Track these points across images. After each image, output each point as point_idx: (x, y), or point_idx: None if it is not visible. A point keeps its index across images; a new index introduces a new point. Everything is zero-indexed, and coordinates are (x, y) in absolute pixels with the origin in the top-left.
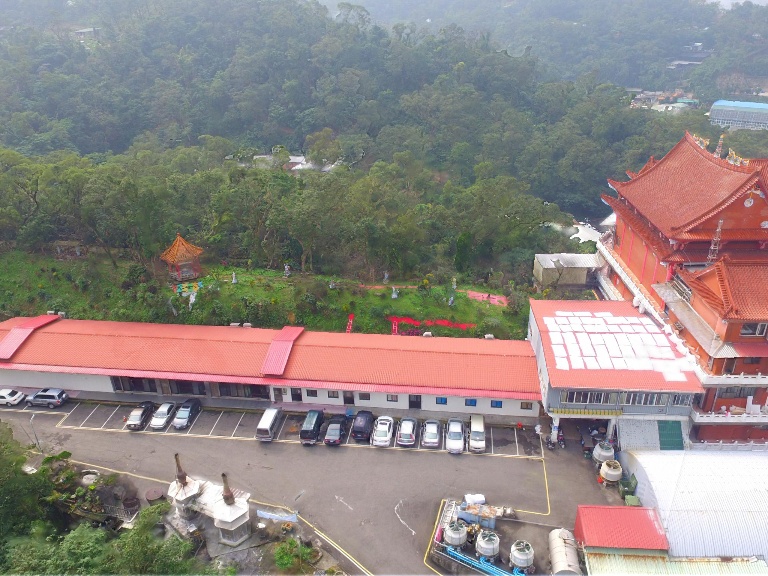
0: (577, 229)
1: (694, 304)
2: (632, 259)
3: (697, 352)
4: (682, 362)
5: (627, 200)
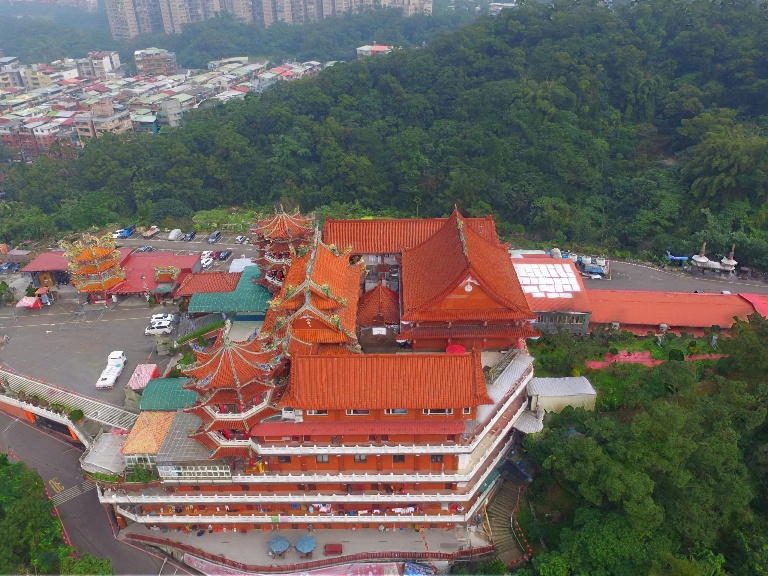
0: (547, 459)
1: None
2: None
3: None
4: None
5: None
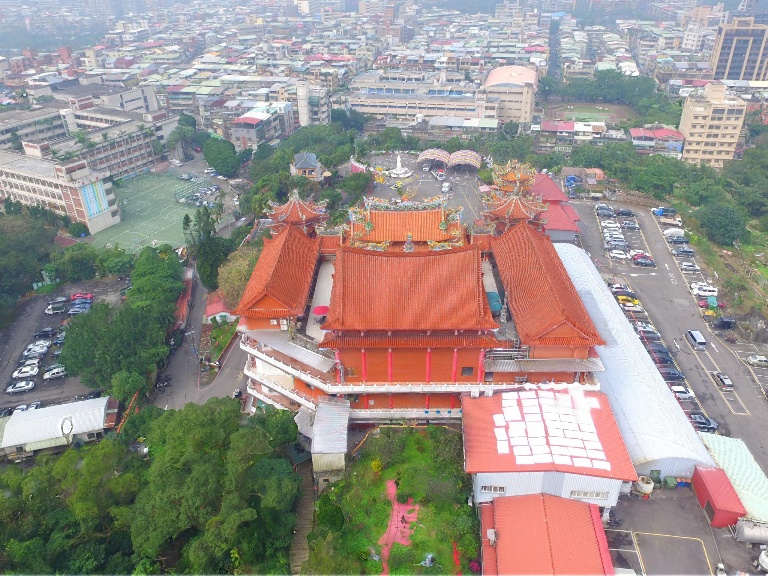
0: None
1: (537, 356)
2: (398, 373)
3: (555, 382)
4: (574, 393)
5: (379, 330)
